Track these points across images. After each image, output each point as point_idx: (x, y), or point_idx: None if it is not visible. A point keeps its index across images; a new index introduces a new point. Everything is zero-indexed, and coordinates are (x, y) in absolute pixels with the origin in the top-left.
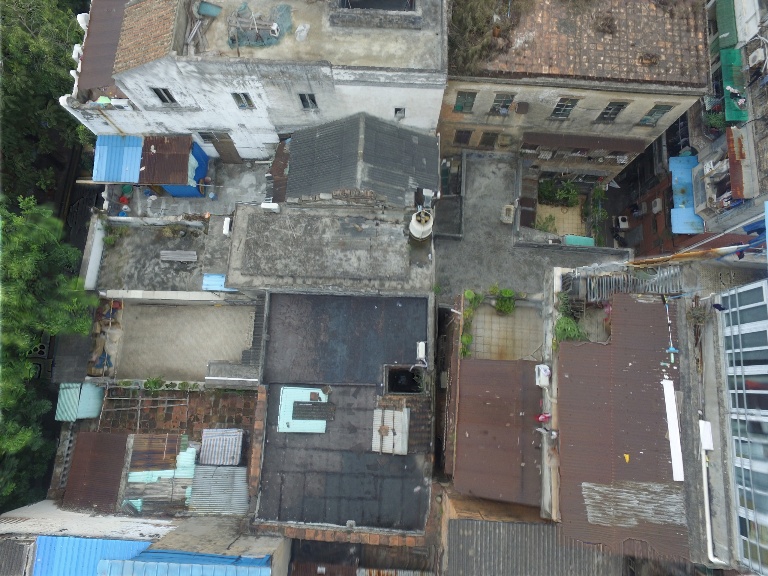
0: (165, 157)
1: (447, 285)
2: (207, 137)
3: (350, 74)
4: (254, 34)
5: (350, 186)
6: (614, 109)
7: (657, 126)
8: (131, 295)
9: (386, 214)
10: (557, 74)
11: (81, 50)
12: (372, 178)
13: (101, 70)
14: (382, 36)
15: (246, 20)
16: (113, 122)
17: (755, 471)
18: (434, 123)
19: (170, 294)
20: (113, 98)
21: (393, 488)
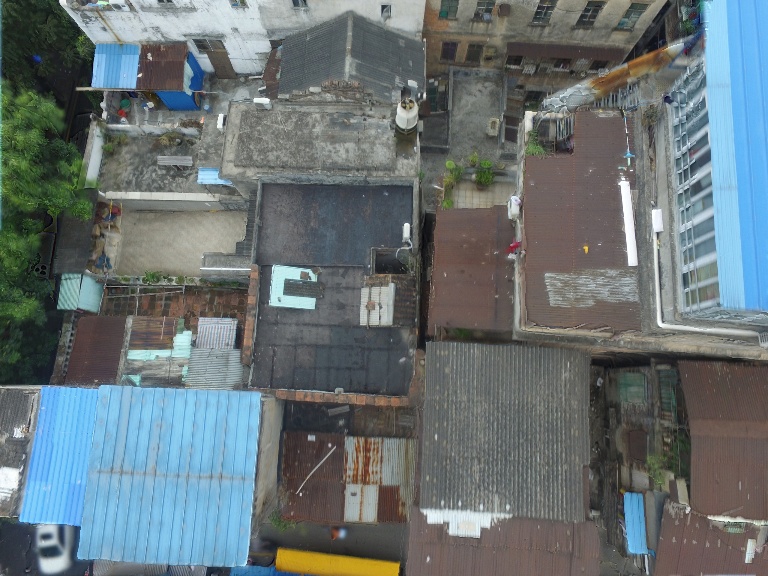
0: (161, 64)
1: (435, 195)
2: (202, 47)
3: None
4: None
5: (338, 80)
6: (593, 11)
7: (635, 30)
8: (129, 196)
9: (373, 111)
10: None
11: None
12: (360, 73)
13: None
14: None
15: None
16: (111, 27)
17: (695, 225)
18: (420, 24)
19: (167, 195)
20: None
21: (379, 359)
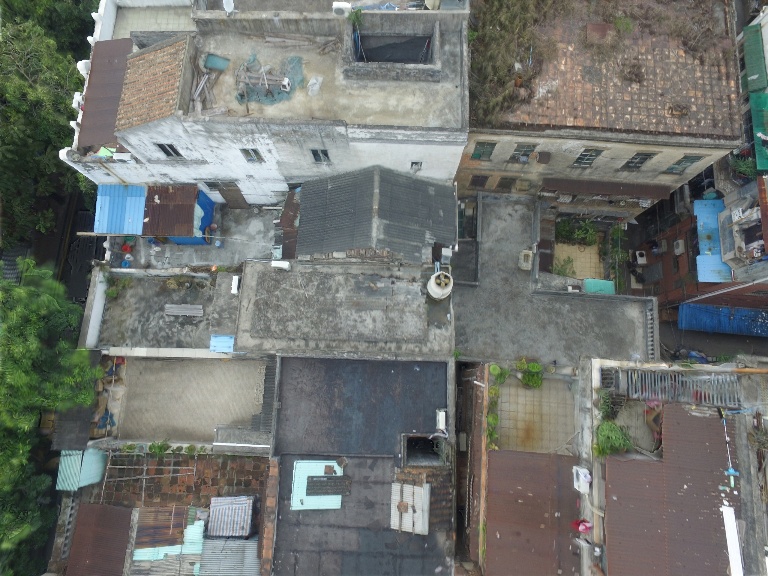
0: (169, 208)
1: (463, 335)
2: (213, 185)
3: (366, 132)
4: (264, 89)
5: (365, 244)
6: (640, 158)
7: (684, 174)
8: (135, 353)
9: (402, 271)
10: (582, 126)
11: (81, 99)
12: (388, 235)
13: (103, 126)
14: (399, 89)
15: (255, 75)
16: (115, 173)
17: None
18: (452, 174)
19: (175, 351)
20: (115, 152)
21: (413, 568)
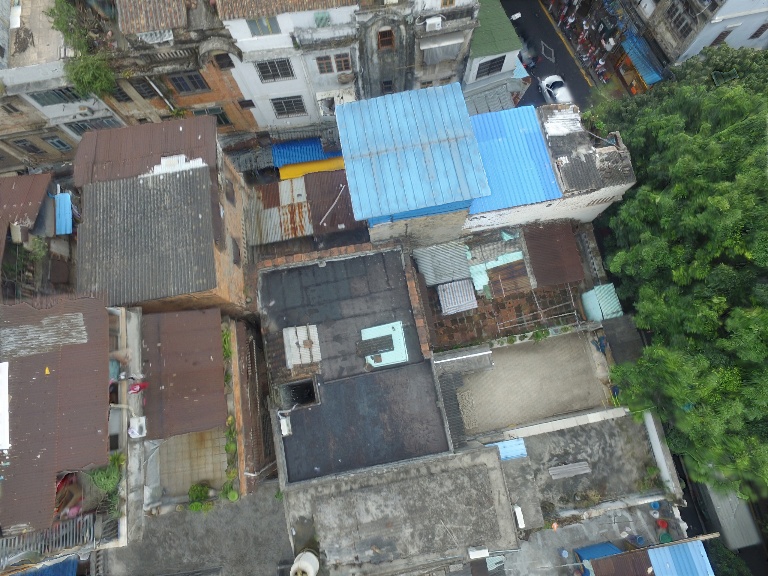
0: None
1: None
2: None
3: None
4: None
5: None
6: None
7: None
8: (599, 415)
9: (350, 574)
10: None
11: None
12: None
13: None
14: None
15: None
16: None
17: None
18: None
19: (560, 426)
20: None
21: (293, 299)
